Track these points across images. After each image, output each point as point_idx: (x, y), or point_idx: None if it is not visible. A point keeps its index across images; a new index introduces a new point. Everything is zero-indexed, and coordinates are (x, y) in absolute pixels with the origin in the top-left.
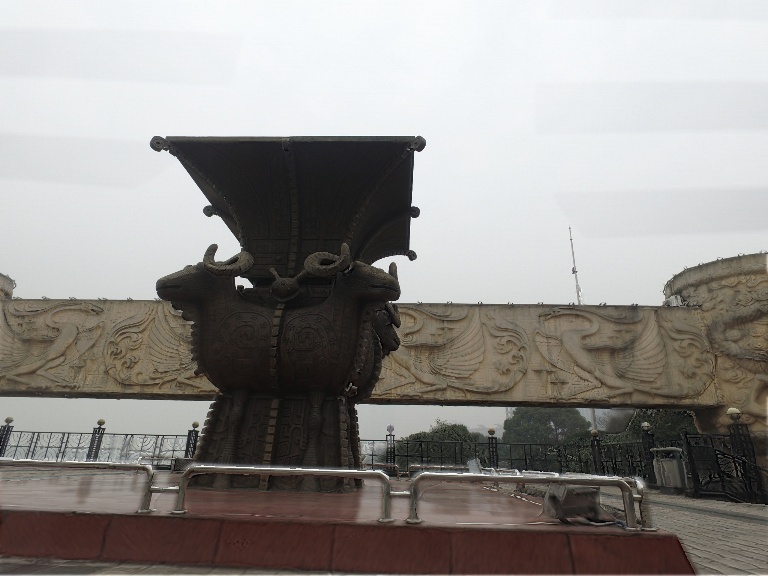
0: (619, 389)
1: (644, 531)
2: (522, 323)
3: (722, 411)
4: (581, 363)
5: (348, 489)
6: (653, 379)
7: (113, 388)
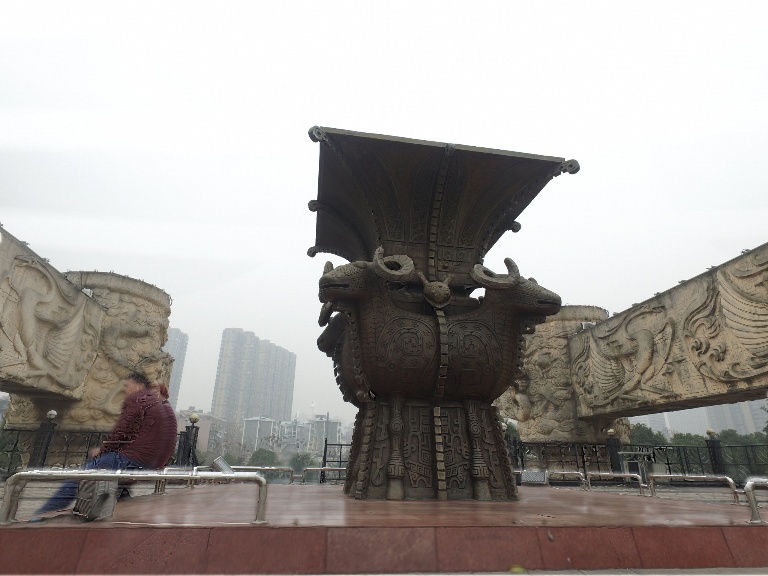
0: (38, 370)
1: None
2: None
3: (77, 404)
4: (26, 332)
5: None
6: None
7: None
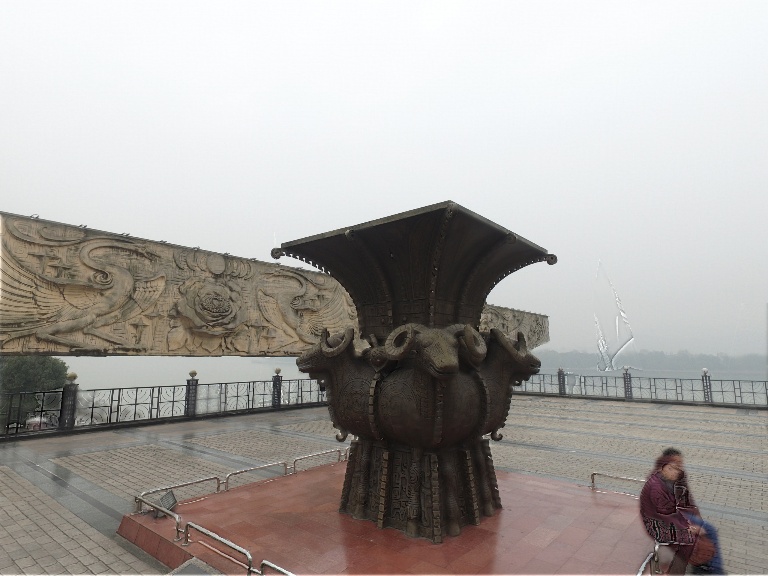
0: None
1: None
2: None
3: None
4: None
5: None
6: None
7: None
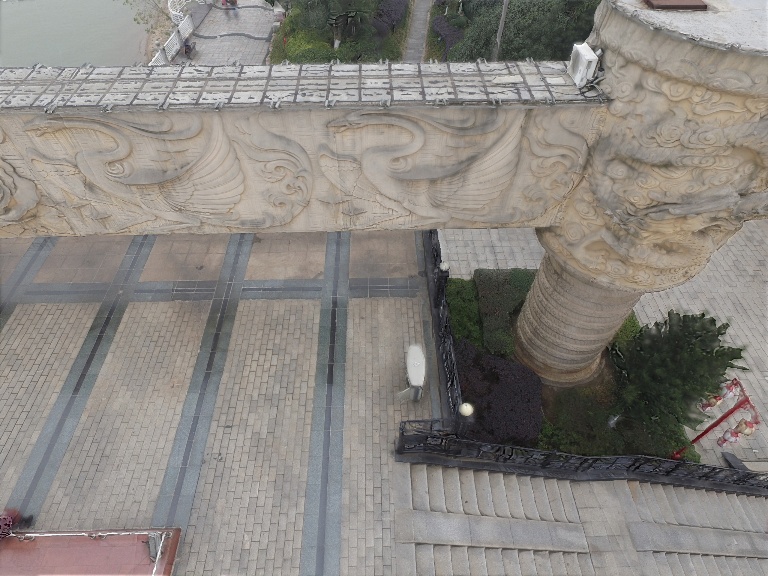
0: (431, 218)
1: None
2: (299, 137)
3: (554, 228)
4: (385, 194)
5: None
6: (481, 206)
7: None
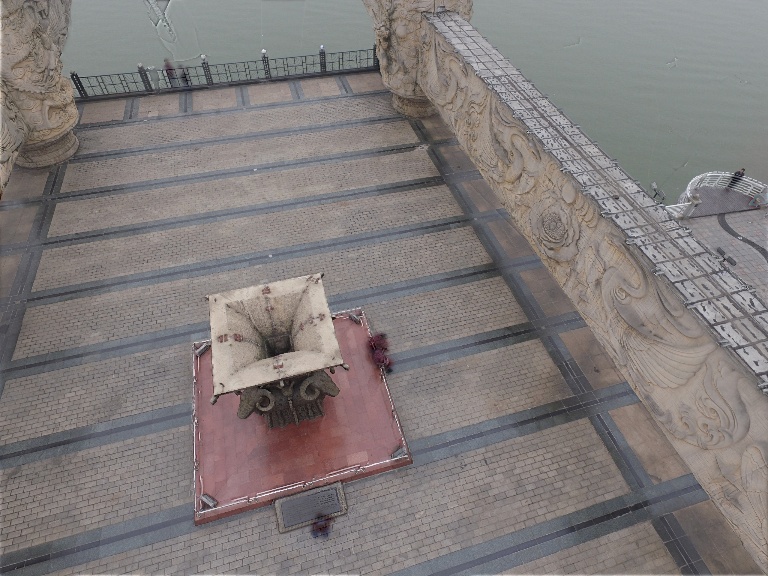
0: None
1: (196, 514)
2: (756, 419)
3: None
4: None
5: (270, 429)
6: None
7: (466, 150)
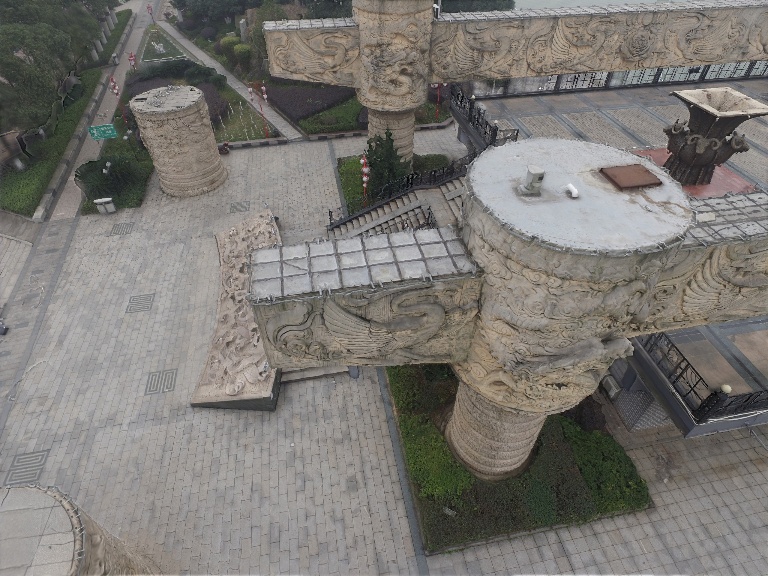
0: None
1: None
2: None
3: None
4: None
5: None
6: None
7: None
